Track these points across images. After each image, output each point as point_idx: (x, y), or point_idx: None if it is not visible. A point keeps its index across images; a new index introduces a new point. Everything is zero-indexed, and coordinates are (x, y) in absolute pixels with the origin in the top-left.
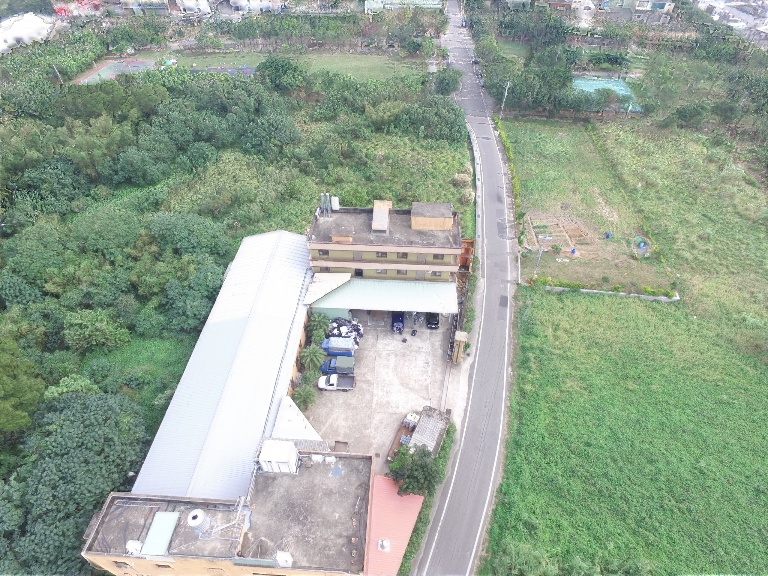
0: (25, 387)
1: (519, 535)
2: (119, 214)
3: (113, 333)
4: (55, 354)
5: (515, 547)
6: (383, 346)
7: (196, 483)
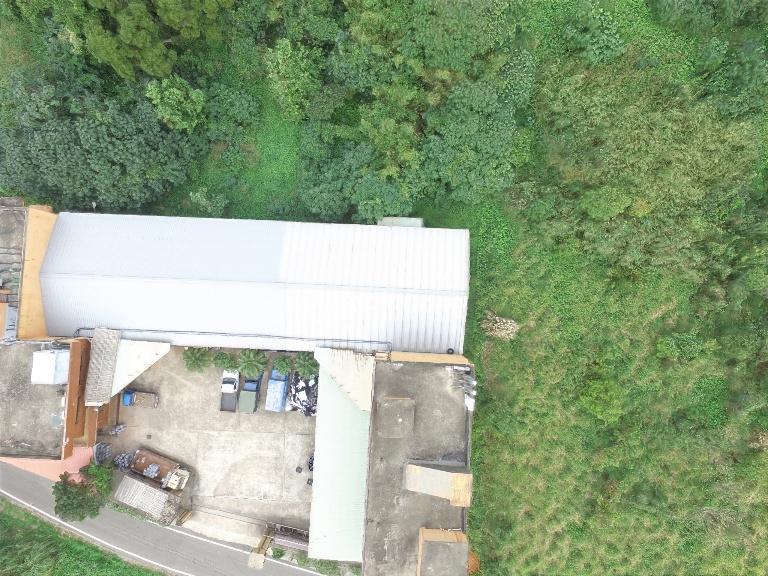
0: (150, 58)
1: (69, 570)
2: (476, 22)
3: (288, 103)
4: (254, 48)
5: (47, 568)
6: (291, 442)
7: (60, 279)
